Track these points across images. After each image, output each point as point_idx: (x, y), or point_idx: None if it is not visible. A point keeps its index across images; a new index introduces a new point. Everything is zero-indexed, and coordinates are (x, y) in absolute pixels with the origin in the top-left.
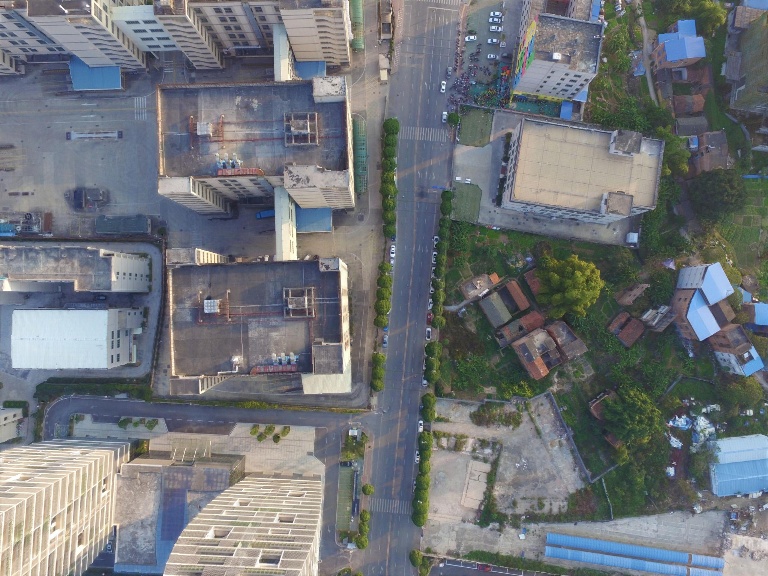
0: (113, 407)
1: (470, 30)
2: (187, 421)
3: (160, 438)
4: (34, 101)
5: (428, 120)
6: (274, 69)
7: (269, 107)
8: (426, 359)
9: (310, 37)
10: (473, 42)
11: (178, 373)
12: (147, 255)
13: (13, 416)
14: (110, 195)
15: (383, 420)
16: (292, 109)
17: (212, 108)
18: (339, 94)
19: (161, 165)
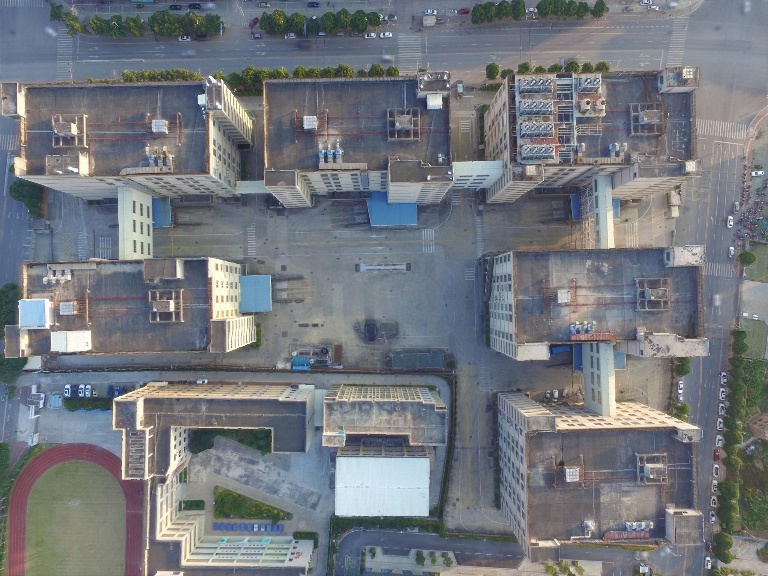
0: (403, 540)
1: (757, 165)
2: (476, 554)
3: (450, 571)
4: (323, 232)
5: (714, 255)
6: (600, 221)
7: (619, 271)
8: (722, 500)
9: (634, 189)
10: (759, 177)
11: (531, 537)
12: (435, 388)
13: (311, 551)
14: (399, 327)
15: (670, 556)
16: (642, 273)
17: (563, 272)
18: (699, 263)
19: (514, 329)
